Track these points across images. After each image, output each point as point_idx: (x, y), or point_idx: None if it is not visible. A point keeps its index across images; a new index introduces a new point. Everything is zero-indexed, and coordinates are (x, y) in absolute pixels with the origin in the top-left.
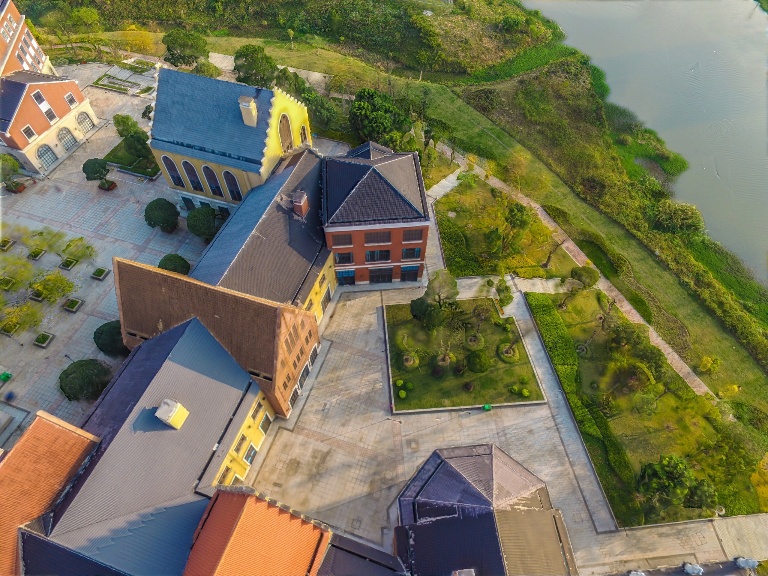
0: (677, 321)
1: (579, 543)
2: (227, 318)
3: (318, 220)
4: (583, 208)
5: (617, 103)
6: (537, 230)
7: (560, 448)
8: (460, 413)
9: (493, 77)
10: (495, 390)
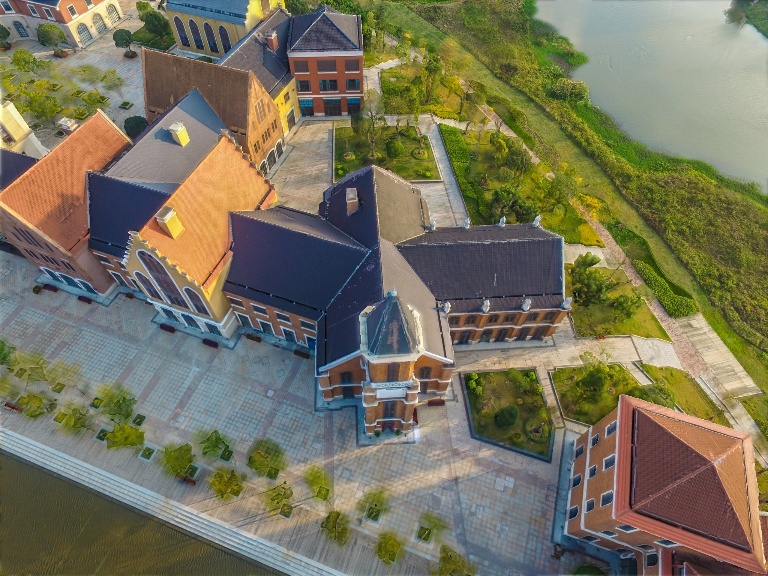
0: (553, 149)
1: None
2: (217, 86)
3: (285, 56)
4: (498, 83)
5: (541, 19)
6: (450, 80)
7: (447, 204)
8: None
9: None
10: (407, 173)
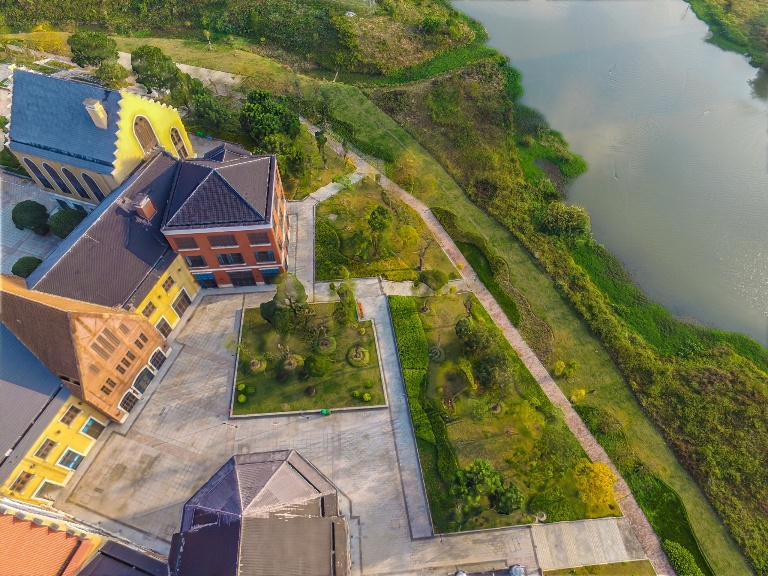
0: (544, 324)
1: (391, 549)
2: (27, 322)
3: None
4: (472, 210)
5: (528, 105)
6: (403, 233)
7: (392, 453)
8: (298, 418)
9: (408, 78)
10: (337, 394)
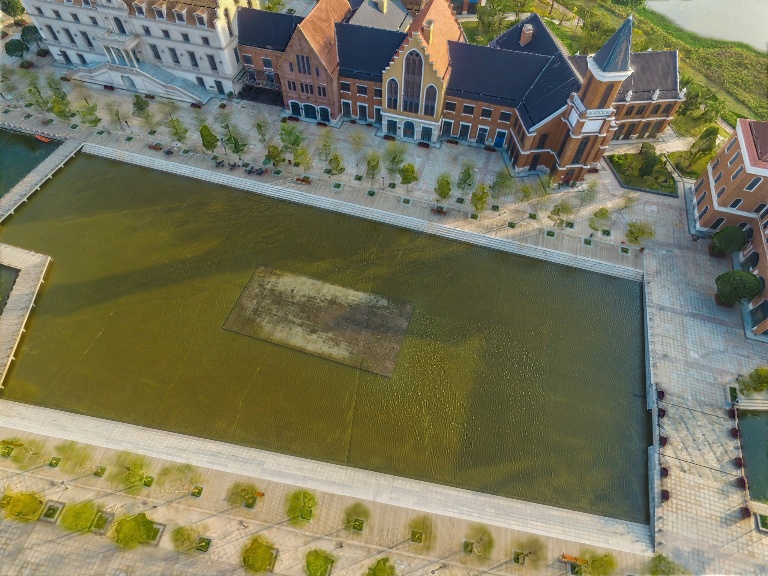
0: None
1: None
2: None
3: None
4: None
5: None
6: None
7: None
8: None
9: None
10: None
